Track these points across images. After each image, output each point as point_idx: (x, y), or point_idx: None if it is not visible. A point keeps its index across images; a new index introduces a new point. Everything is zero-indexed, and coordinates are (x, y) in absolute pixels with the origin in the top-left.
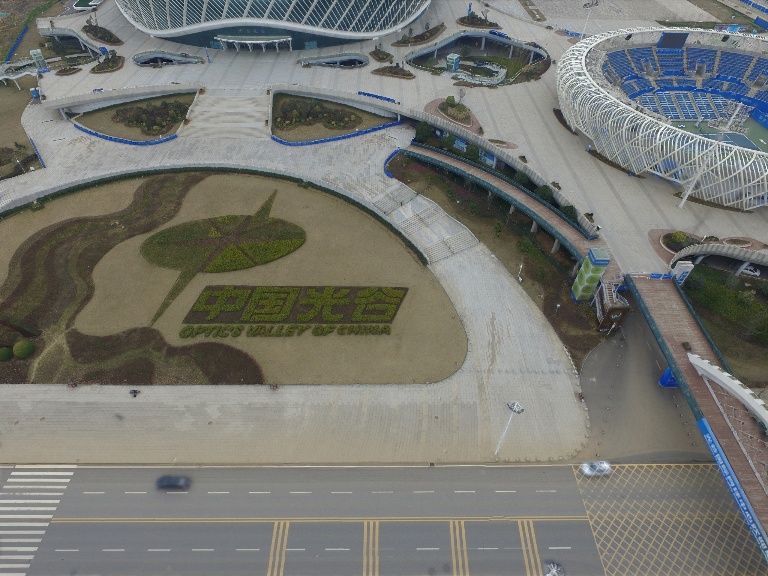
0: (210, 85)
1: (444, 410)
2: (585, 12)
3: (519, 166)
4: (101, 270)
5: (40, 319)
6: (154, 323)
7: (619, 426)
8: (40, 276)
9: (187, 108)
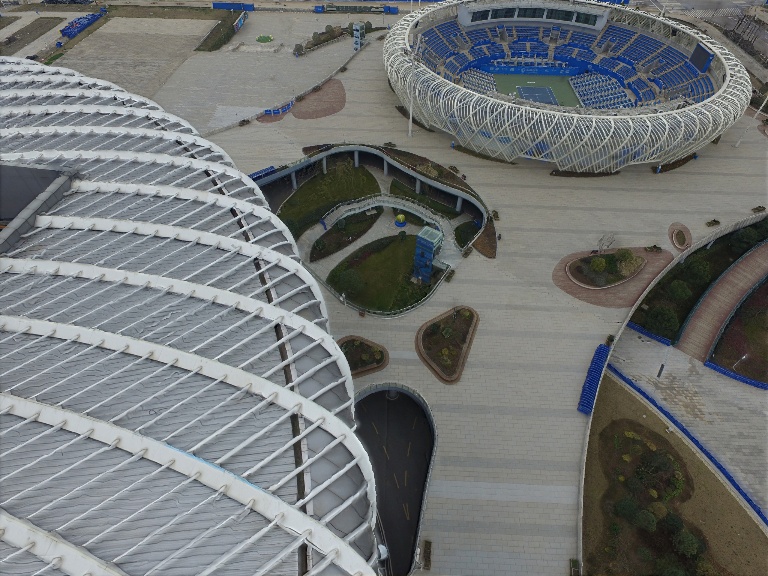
0: None
1: None
2: (129, 86)
3: (729, 230)
4: None
5: None
6: None
7: None
8: None
9: None
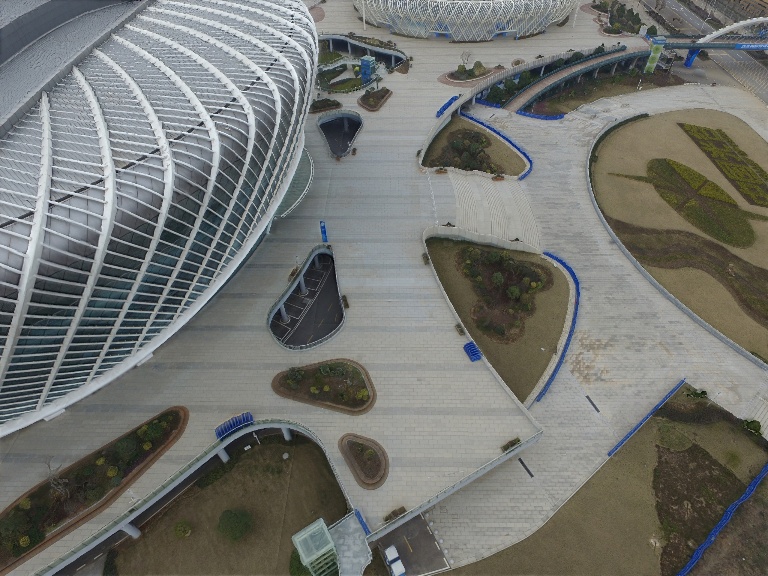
0: None
1: (756, 118)
2: None
3: (548, 60)
4: None
5: None
6: None
7: (721, 80)
8: None
9: None
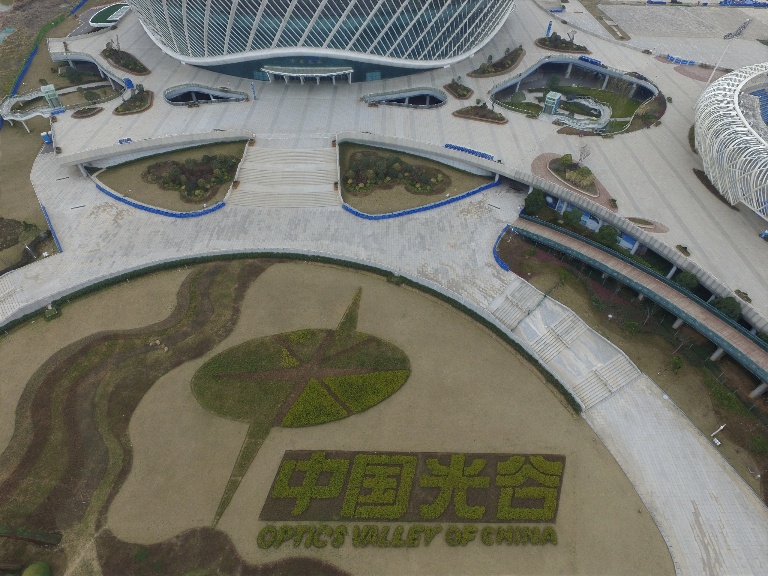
0: (261, 133)
1: None
2: (672, 29)
3: (681, 261)
4: (140, 422)
5: (59, 512)
6: (219, 520)
7: None
8: (58, 432)
9: (234, 163)
